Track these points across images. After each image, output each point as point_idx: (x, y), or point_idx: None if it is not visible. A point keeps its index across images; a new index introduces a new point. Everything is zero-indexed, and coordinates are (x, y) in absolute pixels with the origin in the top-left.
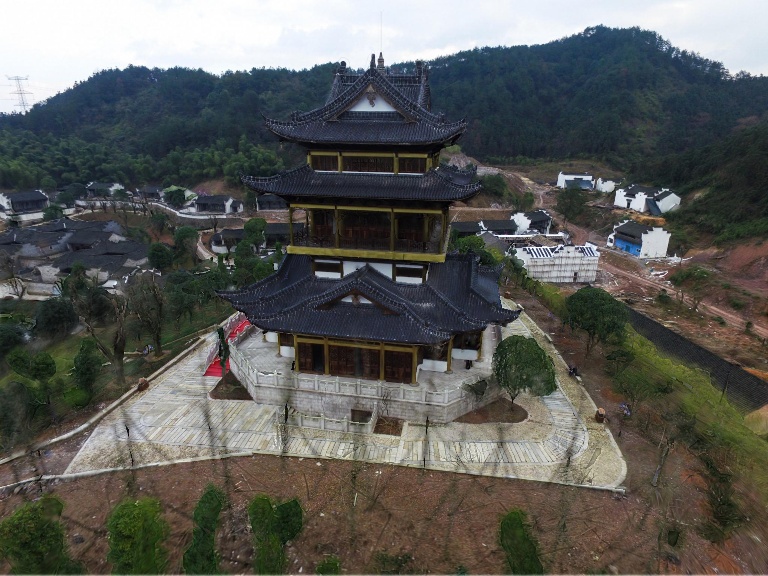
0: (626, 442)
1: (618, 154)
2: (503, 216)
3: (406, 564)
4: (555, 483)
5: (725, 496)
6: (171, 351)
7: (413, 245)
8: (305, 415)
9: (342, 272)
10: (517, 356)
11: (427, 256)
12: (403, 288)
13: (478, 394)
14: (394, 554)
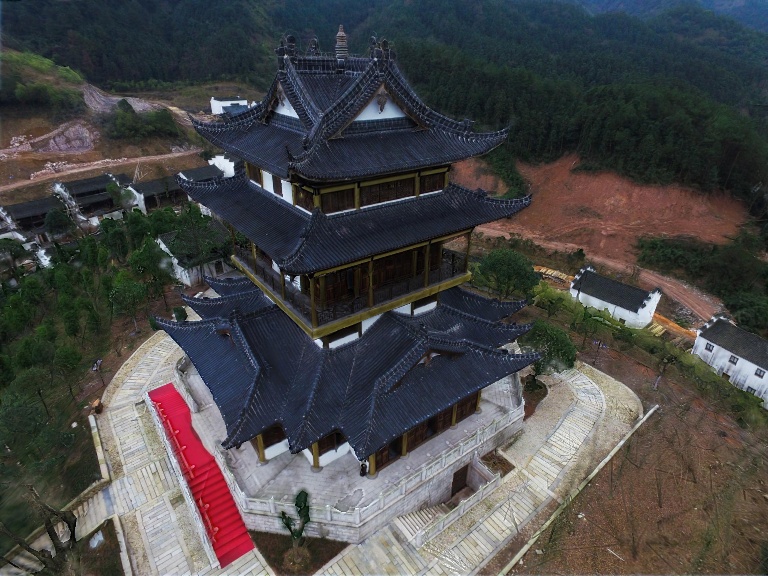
0: (602, 367)
1: (258, 74)
2: (194, 161)
3: (707, 569)
4: (638, 428)
5: (698, 377)
6: (94, 575)
7: (444, 273)
8: (412, 513)
9: (360, 330)
10: (557, 343)
11: (458, 280)
12: (421, 319)
13: (537, 389)
14: (694, 570)
